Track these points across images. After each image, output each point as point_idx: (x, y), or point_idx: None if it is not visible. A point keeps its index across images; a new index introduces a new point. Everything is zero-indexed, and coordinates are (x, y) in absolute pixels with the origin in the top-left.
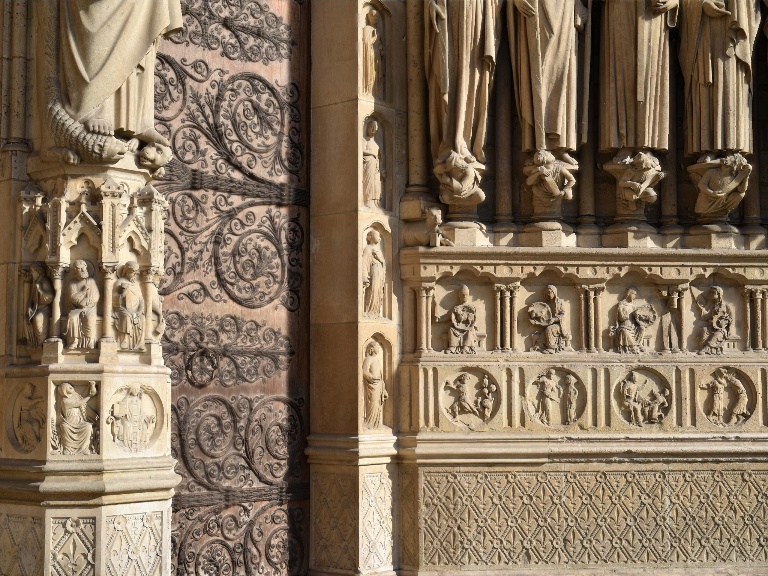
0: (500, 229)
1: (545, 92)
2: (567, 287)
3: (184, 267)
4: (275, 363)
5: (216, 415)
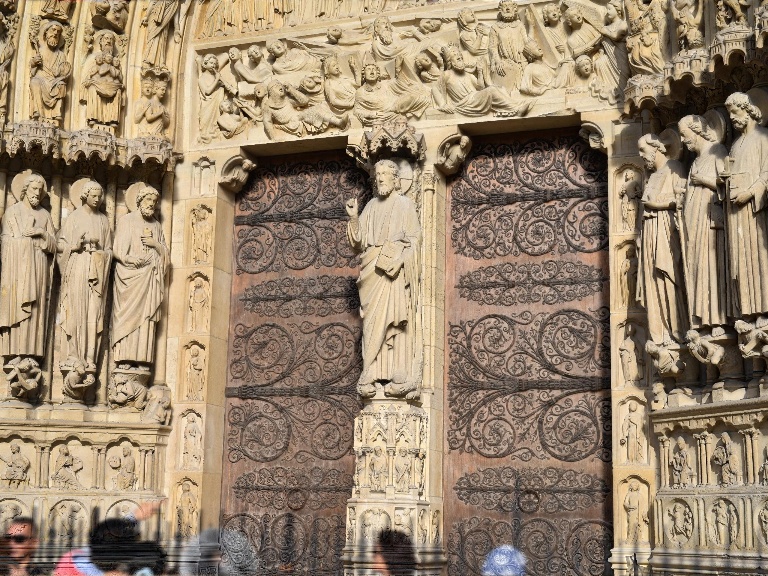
0: None
1: (693, 285)
2: None
3: (516, 439)
4: (592, 498)
5: (541, 531)
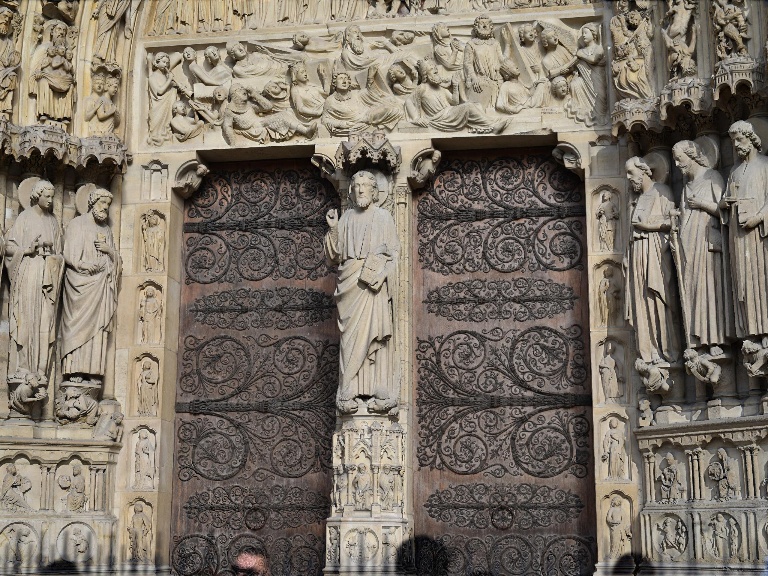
0: (693, 408)
1: (690, 305)
2: (735, 449)
3: (488, 456)
4: (566, 513)
5: (515, 547)
